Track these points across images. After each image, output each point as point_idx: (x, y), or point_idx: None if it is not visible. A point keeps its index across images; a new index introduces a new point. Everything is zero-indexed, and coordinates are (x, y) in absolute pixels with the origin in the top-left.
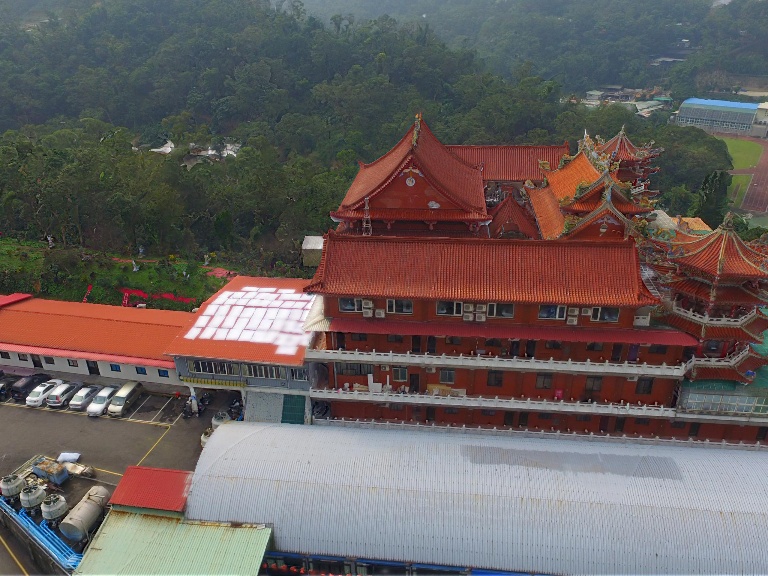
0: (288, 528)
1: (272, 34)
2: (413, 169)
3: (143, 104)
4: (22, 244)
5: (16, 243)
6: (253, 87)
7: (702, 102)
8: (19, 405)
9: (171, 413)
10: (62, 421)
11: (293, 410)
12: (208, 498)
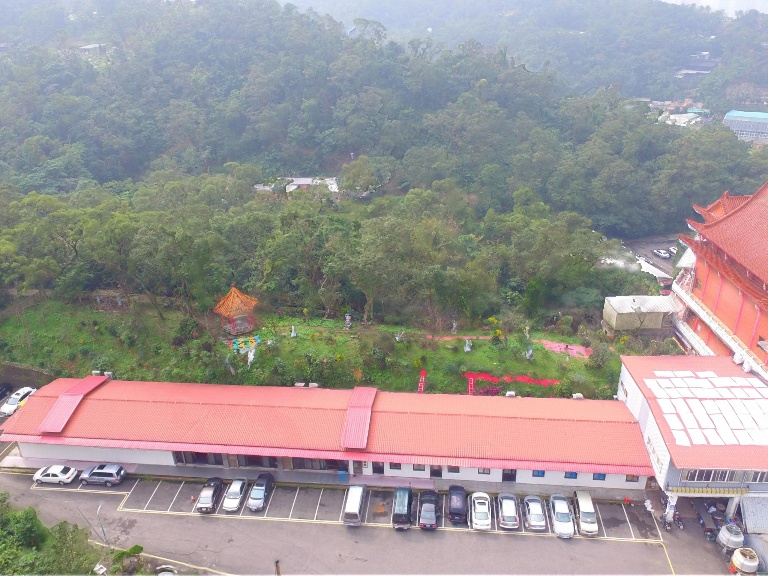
0: None
1: (363, 61)
2: None
3: (241, 139)
4: (311, 324)
5: (303, 323)
6: (360, 118)
7: (745, 114)
8: (463, 529)
9: (644, 526)
10: (535, 547)
11: None
12: None
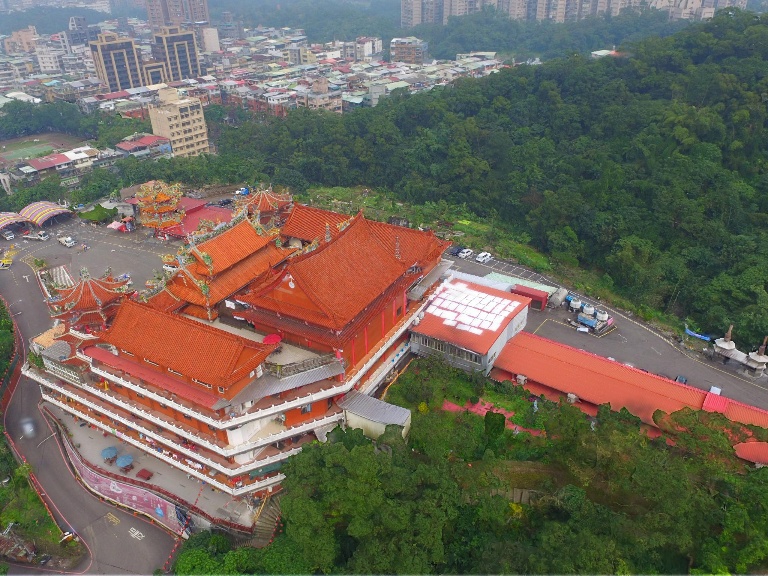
0: None
1: None
2: None
3: None
4: None
5: None
6: None
7: None
8: None
9: None
10: (601, 355)
11: None
12: None
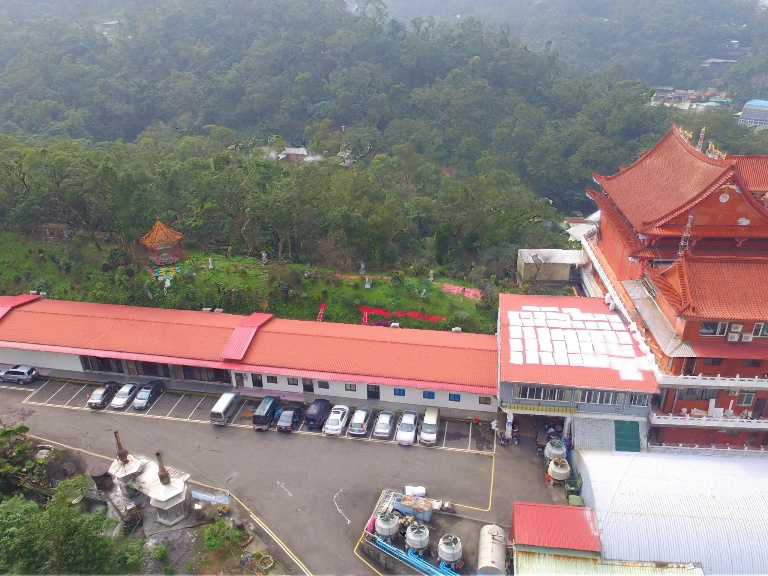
0: (718, 567)
1: (360, 37)
2: (730, 185)
3: None
4: (231, 260)
5: (225, 259)
6: (350, 91)
7: (766, 103)
8: (316, 433)
9: (483, 440)
10: (375, 451)
11: (627, 437)
12: (623, 537)
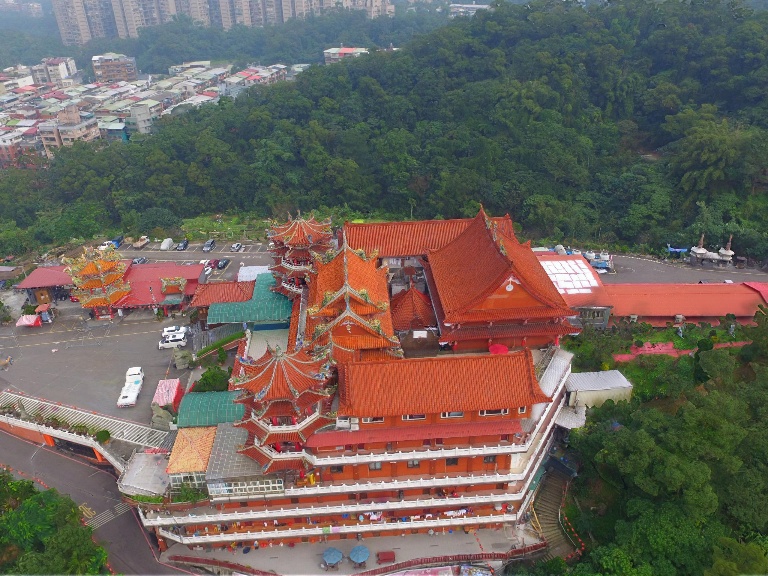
0: None
1: None
2: None
3: None
4: None
5: None
6: None
7: None
8: None
9: None
10: None
11: None
12: None
